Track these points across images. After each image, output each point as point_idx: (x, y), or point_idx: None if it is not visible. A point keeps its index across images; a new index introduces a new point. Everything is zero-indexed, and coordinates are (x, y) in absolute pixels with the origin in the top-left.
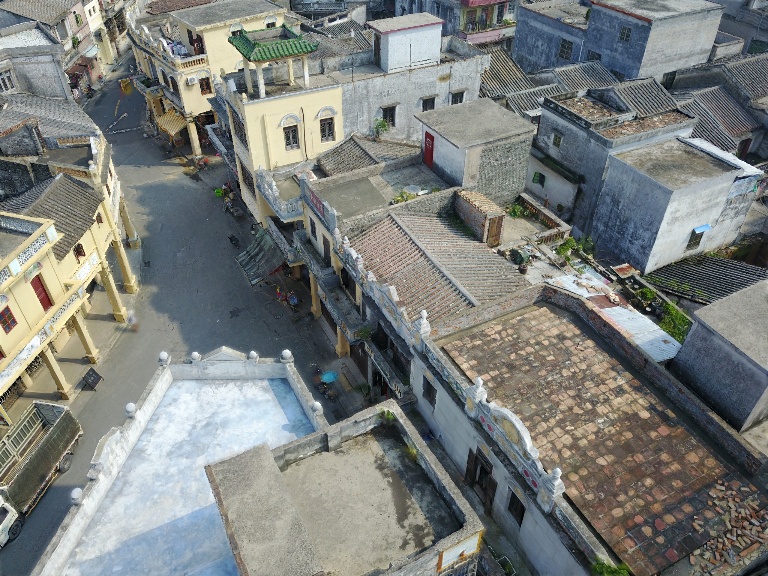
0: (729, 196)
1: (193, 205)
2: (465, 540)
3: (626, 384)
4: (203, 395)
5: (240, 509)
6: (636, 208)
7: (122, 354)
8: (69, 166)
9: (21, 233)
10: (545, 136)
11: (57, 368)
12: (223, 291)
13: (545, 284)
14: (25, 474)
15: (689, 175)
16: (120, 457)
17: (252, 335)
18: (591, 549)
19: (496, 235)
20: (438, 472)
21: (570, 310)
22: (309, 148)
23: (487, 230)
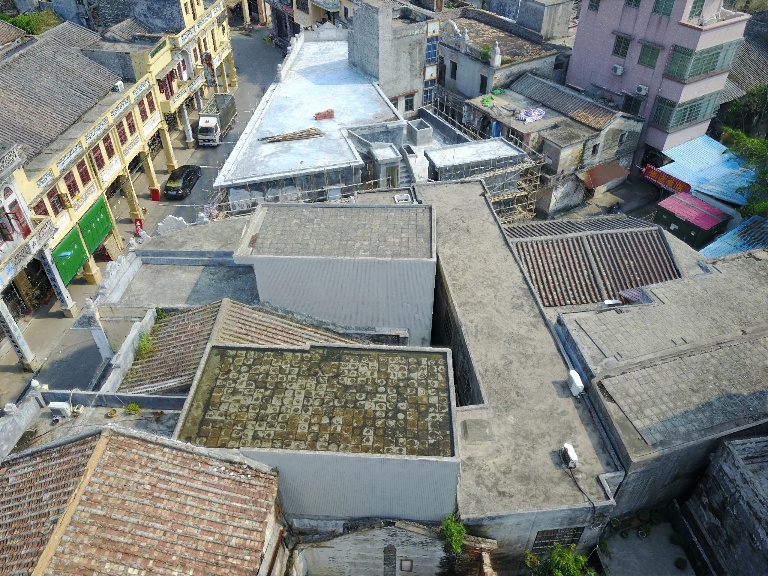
0: None
1: (253, 46)
2: (435, 23)
3: None
4: (319, 44)
5: (367, 1)
6: None
7: (241, 97)
8: None
9: None
10: None
11: None
12: None
13: (463, 7)
14: (223, 114)
15: None
16: None
17: None
18: None
19: (440, 8)
20: (424, 13)
21: (474, 18)
22: None
23: (436, 4)
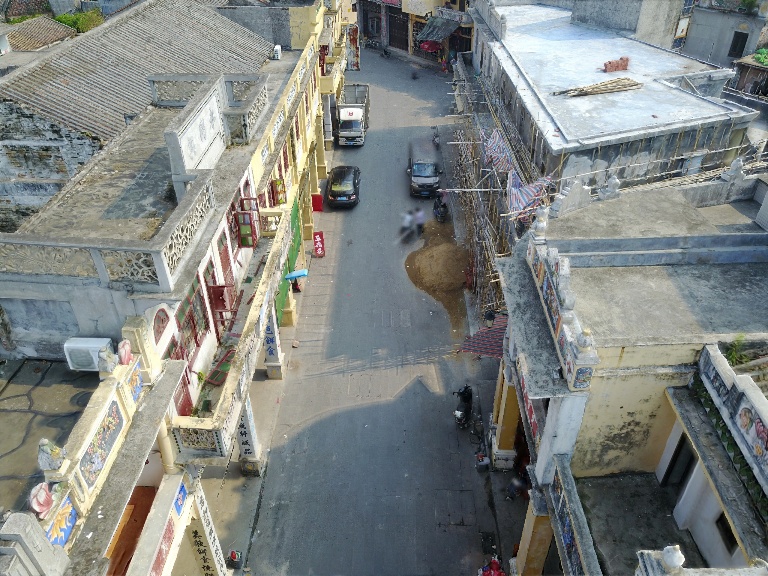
0: None
1: None
2: None
3: None
4: None
5: None
6: None
7: None
8: None
9: None
10: None
11: None
12: (398, 72)
13: None
14: None
15: None
16: None
17: (436, 83)
18: (736, 1)
19: None
20: None
21: None
22: None
23: None
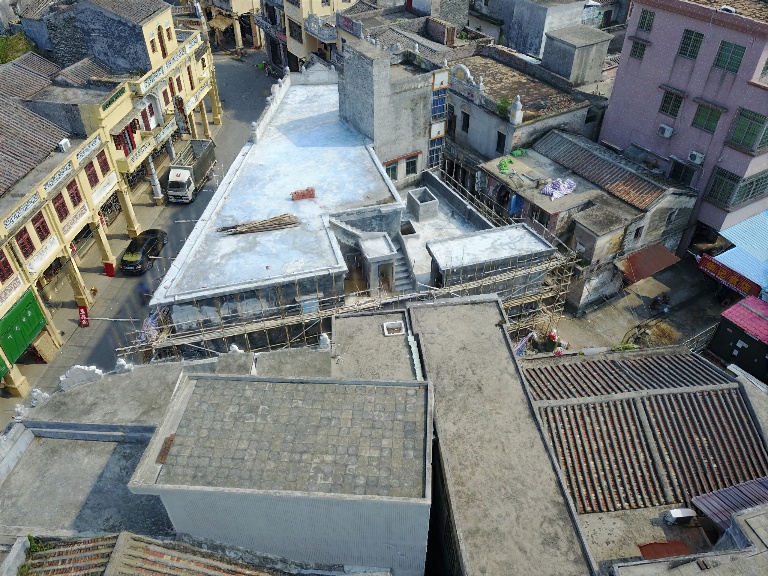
0: (583, 18)
1: (244, 73)
2: (443, 73)
3: (517, 74)
4: (308, 89)
5: None
6: (530, 26)
7: (224, 138)
8: (187, 18)
9: (178, 41)
10: (479, 1)
11: (196, 130)
12: None
13: (478, 44)
14: (198, 165)
15: (558, 3)
16: (278, 100)
17: None
18: None
19: (451, 40)
20: (431, 60)
21: (491, 56)
22: (335, 6)
23: (446, 36)
